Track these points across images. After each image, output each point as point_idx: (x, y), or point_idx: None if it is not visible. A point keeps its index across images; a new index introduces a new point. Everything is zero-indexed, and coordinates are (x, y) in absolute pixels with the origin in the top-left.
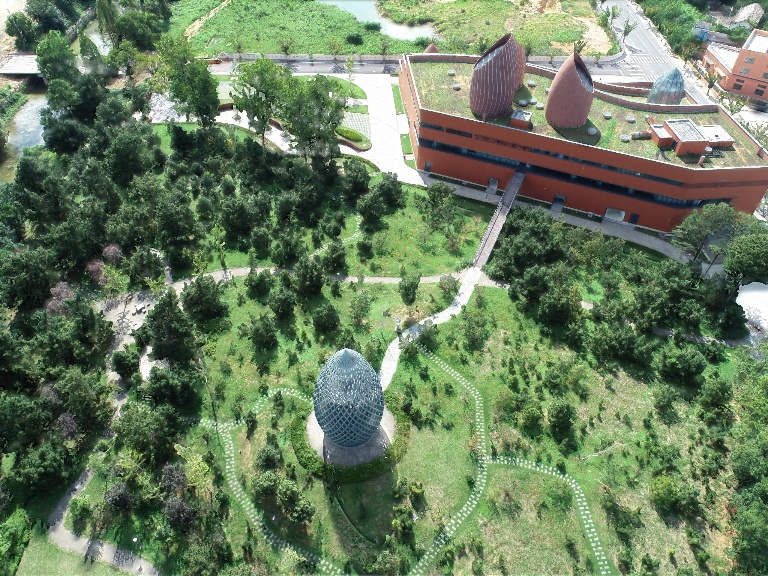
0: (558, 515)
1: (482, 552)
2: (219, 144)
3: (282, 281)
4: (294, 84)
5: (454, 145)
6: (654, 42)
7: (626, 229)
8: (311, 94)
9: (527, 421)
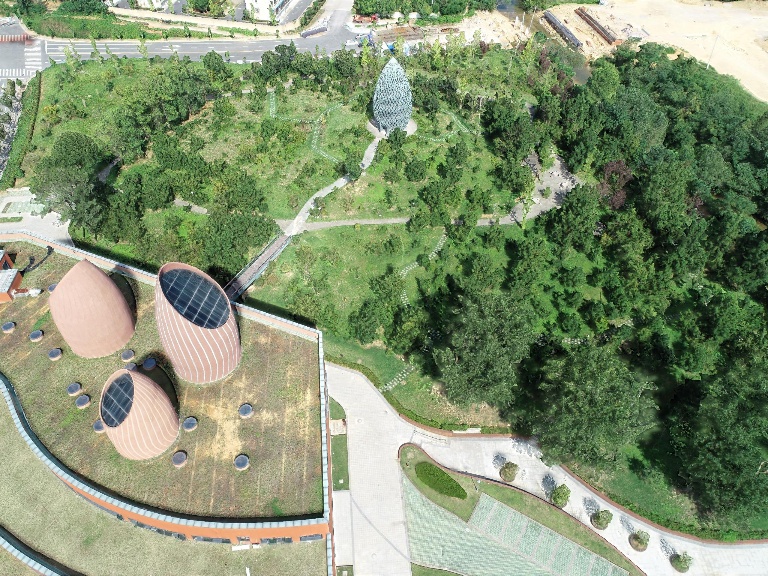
0: None
1: None
2: None
3: None
4: None
5: None
6: None
7: None
8: None
9: None
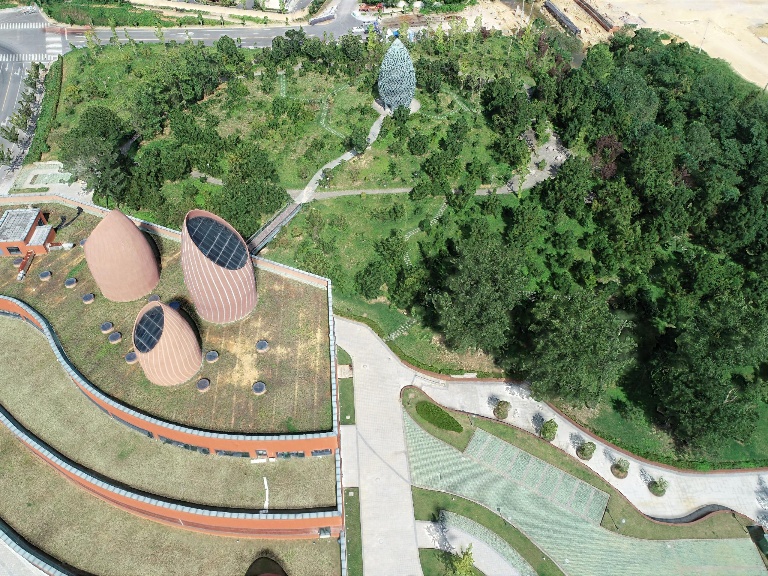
0: None
1: None
2: None
3: None
4: None
5: None
6: None
7: None
8: None
9: None
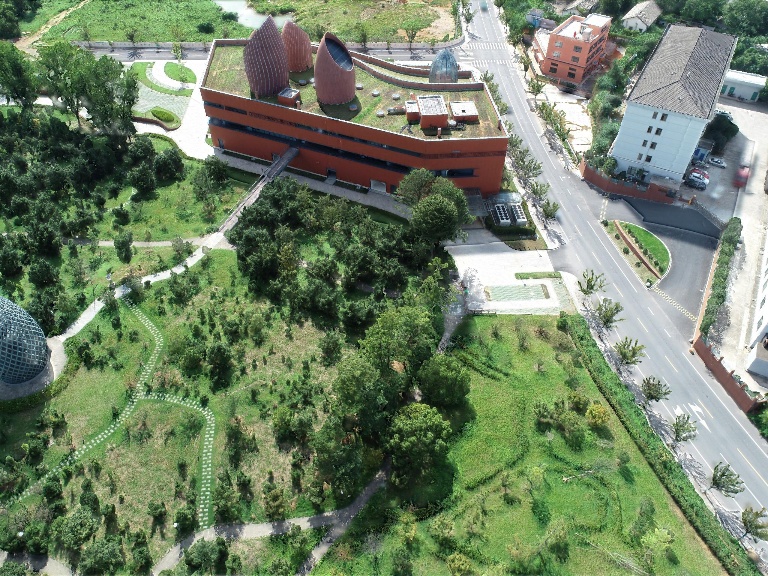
0: (181, 441)
1: (99, 472)
2: (26, 123)
3: (18, 243)
4: (77, 65)
5: (235, 122)
6: (497, 30)
7: (387, 199)
8: (91, 74)
9: (185, 362)
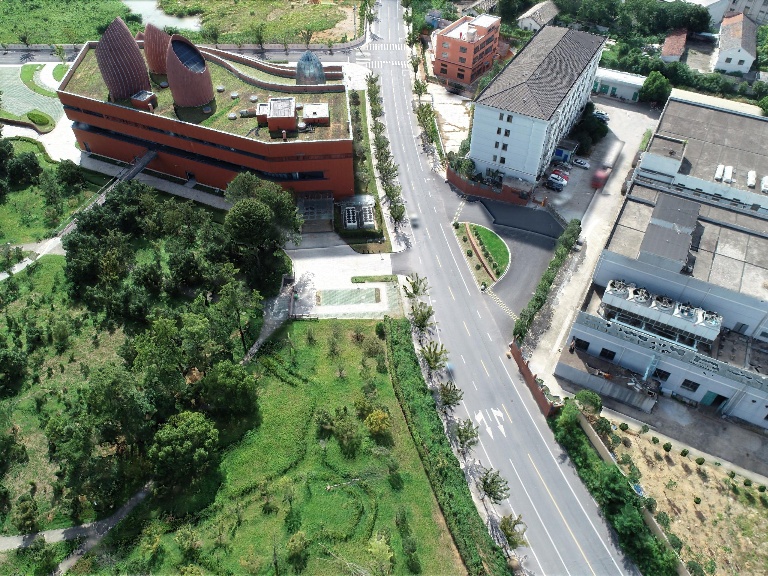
0: None
1: None
2: None
3: None
4: None
5: (95, 125)
6: (401, 30)
7: None
8: None
9: None
